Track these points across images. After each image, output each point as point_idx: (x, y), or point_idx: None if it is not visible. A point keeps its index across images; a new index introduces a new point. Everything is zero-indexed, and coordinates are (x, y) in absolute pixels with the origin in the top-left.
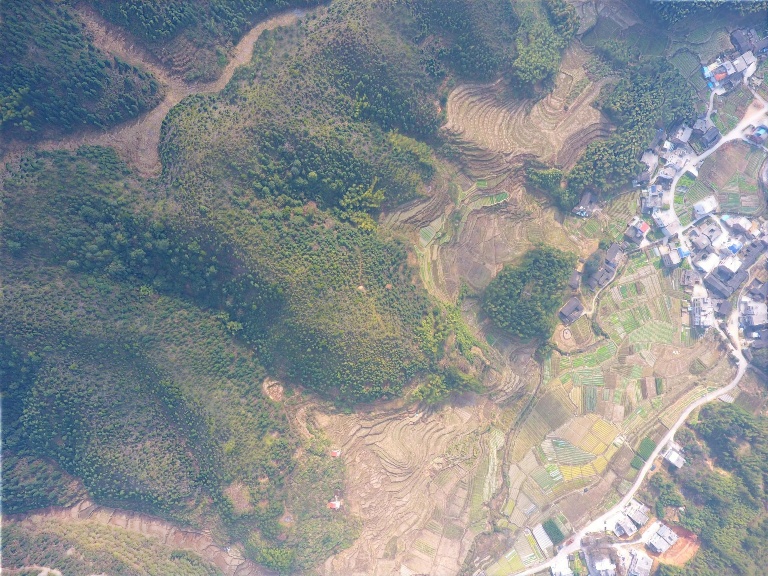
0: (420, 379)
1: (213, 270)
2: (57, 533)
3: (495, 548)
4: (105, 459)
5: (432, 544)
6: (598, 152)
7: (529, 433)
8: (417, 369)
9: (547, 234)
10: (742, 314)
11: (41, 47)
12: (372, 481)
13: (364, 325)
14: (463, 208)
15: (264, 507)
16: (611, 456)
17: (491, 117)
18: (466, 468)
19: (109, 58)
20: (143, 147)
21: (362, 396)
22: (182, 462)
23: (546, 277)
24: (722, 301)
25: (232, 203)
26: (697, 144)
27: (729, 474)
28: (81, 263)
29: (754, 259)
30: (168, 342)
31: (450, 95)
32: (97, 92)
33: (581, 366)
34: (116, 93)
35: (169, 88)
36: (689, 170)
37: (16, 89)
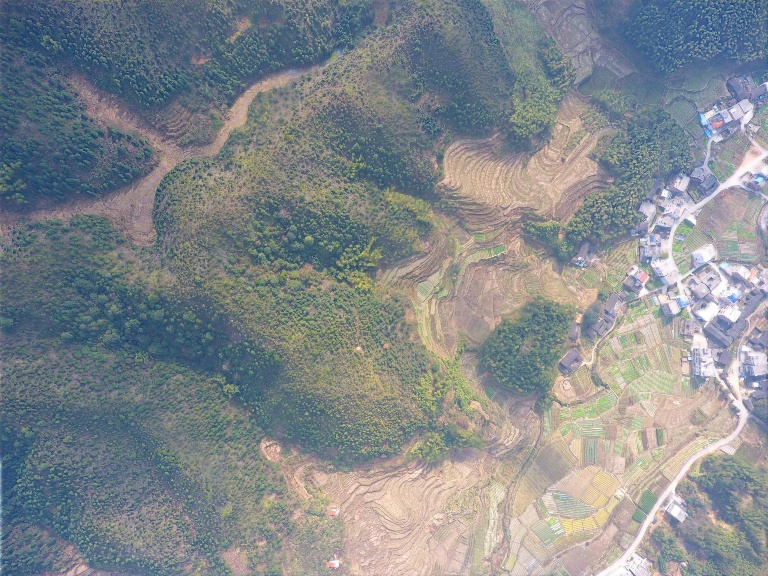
0: (419, 436)
1: (209, 337)
2: None
3: None
4: (100, 529)
5: None
6: (596, 205)
7: (530, 486)
8: (416, 427)
9: (545, 285)
10: (742, 364)
11: (33, 121)
12: (371, 539)
13: (362, 387)
14: (461, 261)
15: (262, 571)
16: (612, 509)
17: (488, 171)
18: (466, 523)
19: (102, 127)
20: (137, 214)
21: (361, 456)
22: (179, 527)
23: (545, 332)
24: (722, 351)
25: (227, 272)
26: (695, 192)
27: (731, 528)
28: (75, 334)
29: (754, 308)
30: (164, 410)
31: (447, 151)
32: (90, 162)
33: (581, 417)
34: (110, 162)
35: (163, 153)
36: (687, 218)
37: (8, 164)
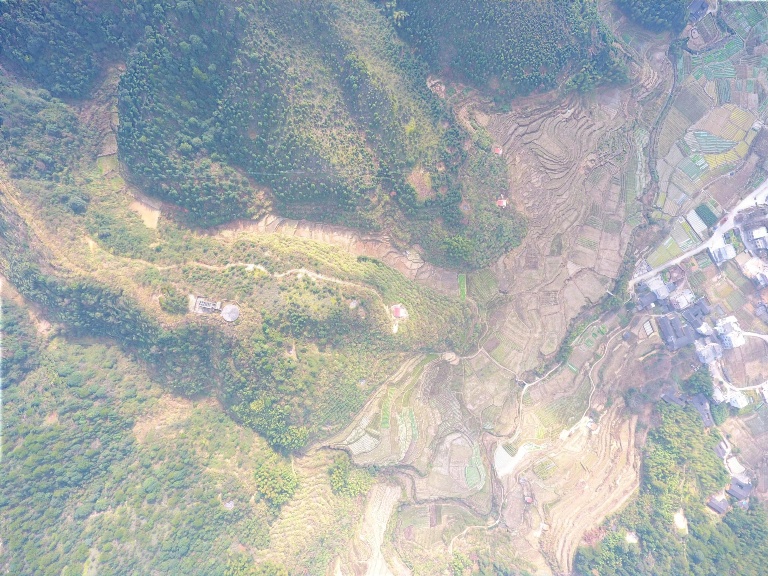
0: (571, 69)
1: None
2: (251, 240)
3: (652, 239)
4: (301, 139)
5: (594, 238)
6: None
7: (671, 129)
8: (570, 54)
9: None
10: None
11: None
12: (533, 180)
13: None
14: None
15: (444, 194)
16: (751, 141)
17: None
18: (617, 164)
19: None
20: None
21: (522, 83)
22: (364, 155)
23: None
24: None
25: None
26: None
27: None
28: None
29: None
30: (349, 17)
31: None
32: None
33: (712, 62)
34: None
35: None
36: None
37: None
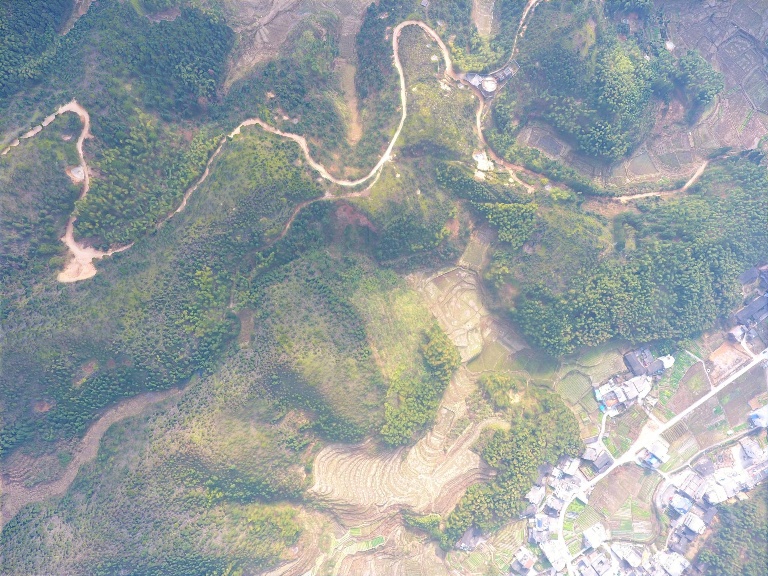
0: None
1: None
2: None
3: None
4: None
5: None
6: (475, 503)
7: None
8: None
9: (428, 570)
10: None
11: None
12: None
13: None
14: (337, 554)
15: None
16: None
17: (363, 469)
18: None
19: None
20: None
21: None
22: None
23: None
24: None
25: None
26: (588, 468)
27: None
28: None
29: None
30: None
31: (317, 456)
32: None
33: None
34: None
35: (8, 495)
36: (579, 498)
37: None
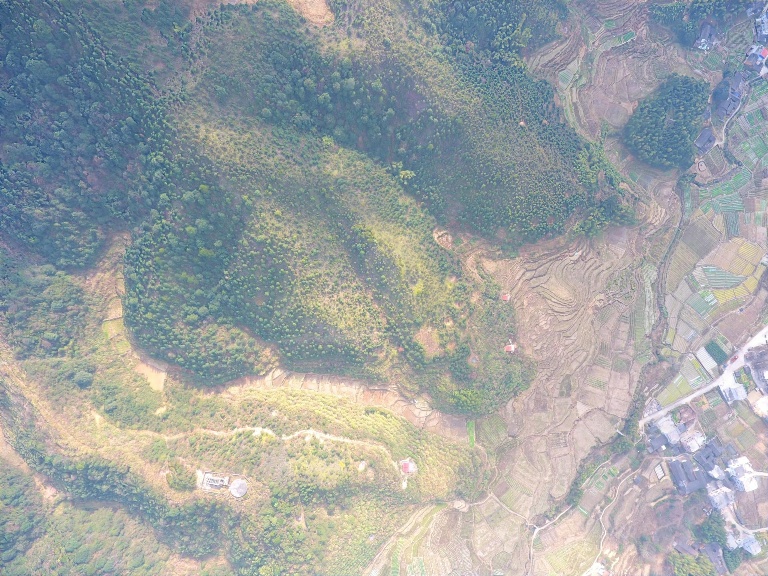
0: (579, 215)
1: (392, 111)
2: (258, 399)
3: (662, 376)
4: (308, 309)
5: (603, 378)
6: None
7: (679, 264)
8: (578, 203)
9: (673, 70)
10: None
11: None
12: (541, 323)
13: (531, 157)
14: (594, 51)
15: (452, 349)
16: (760, 275)
17: None
18: (626, 302)
19: None
20: None
21: (530, 234)
22: (371, 313)
23: (686, 102)
24: None
25: (409, 37)
26: None
27: None
28: (272, 113)
29: None
30: (356, 187)
31: None
32: None
33: (720, 195)
34: None
35: None
36: None
37: None
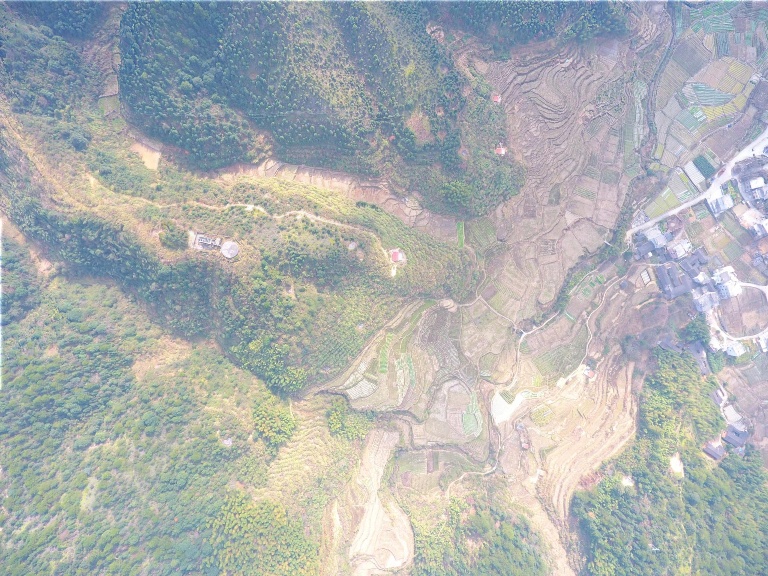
0: (570, 18)
1: None
2: (251, 183)
3: (650, 190)
4: (301, 79)
5: (592, 189)
6: None
7: (669, 81)
8: (569, 2)
9: None
10: None
11: None
12: (531, 129)
13: None
14: None
15: (443, 139)
16: (749, 93)
17: None
18: (615, 115)
19: None
20: None
21: (521, 30)
22: (363, 98)
23: None
24: None
25: None
26: None
27: None
28: None
29: None
30: None
31: None
32: None
33: (710, 15)
34: None
35: None
36: None
37: None
